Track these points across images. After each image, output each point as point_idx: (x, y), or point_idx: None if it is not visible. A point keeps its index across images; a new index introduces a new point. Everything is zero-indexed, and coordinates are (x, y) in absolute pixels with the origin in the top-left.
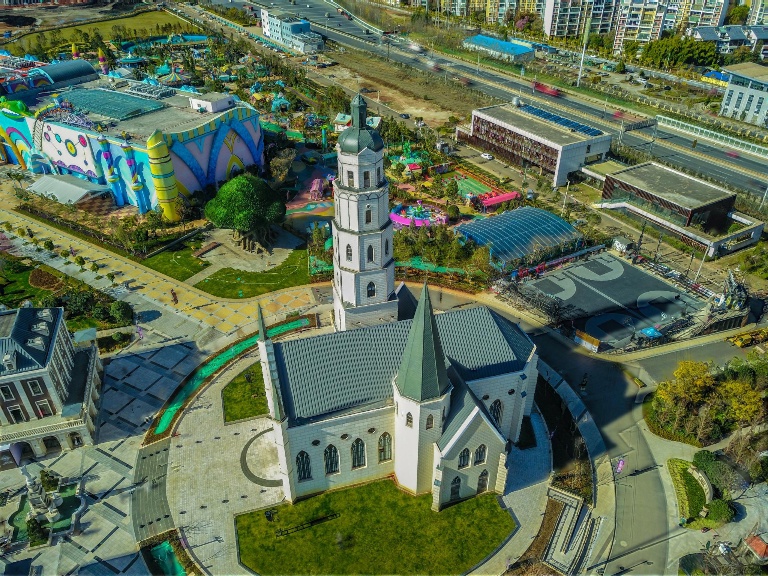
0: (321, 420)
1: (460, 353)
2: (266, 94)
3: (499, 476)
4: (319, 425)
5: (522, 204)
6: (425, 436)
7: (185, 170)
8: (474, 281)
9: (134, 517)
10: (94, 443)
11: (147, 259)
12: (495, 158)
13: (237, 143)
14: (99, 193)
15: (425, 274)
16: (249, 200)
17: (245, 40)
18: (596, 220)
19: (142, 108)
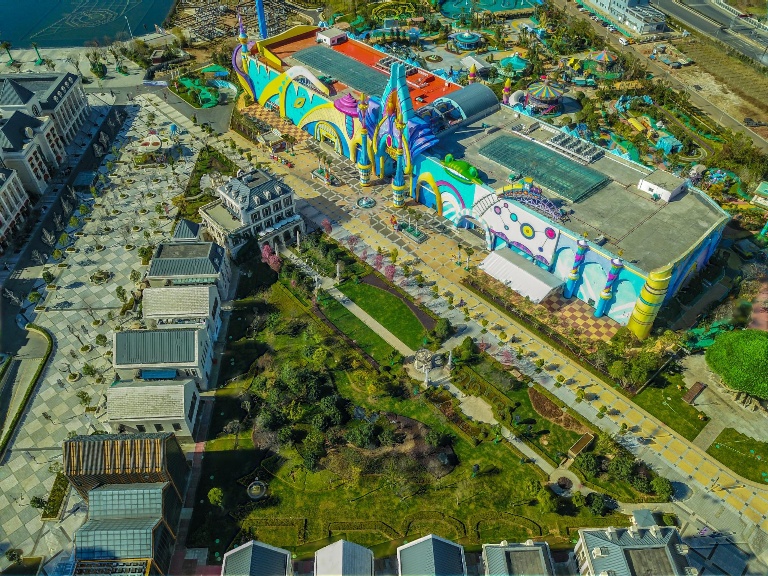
0: None
1: None
2: (640, 118)
3: None
4: None
5: None
6: None
7: None
8: None
9: None
10: None
11: (638, 396)
12: None
13: None
14: (557, 288)
15: None
16: None
17: (587, 21)
18: None
19: (591, 186)
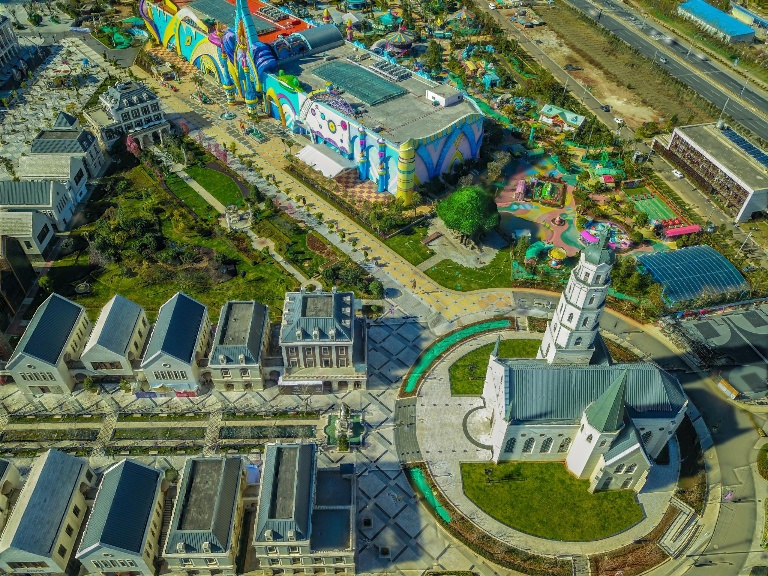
0: (531, 424)
1: (632, 398)
2: (477, 61)
3: (639, 482)
4: (529, 427)
5: (701, 238)
6: (597, 450)
7: (421, 165)
8: (645, 313)
9: (397, 446)
10: (367, 388)
11: (388, 239)
12: (686, 177)
13: (462, 141)
14: (350, 169)
15: None
16: (475, 211)
17: None
18: (766, 276)
19: (388, 95)
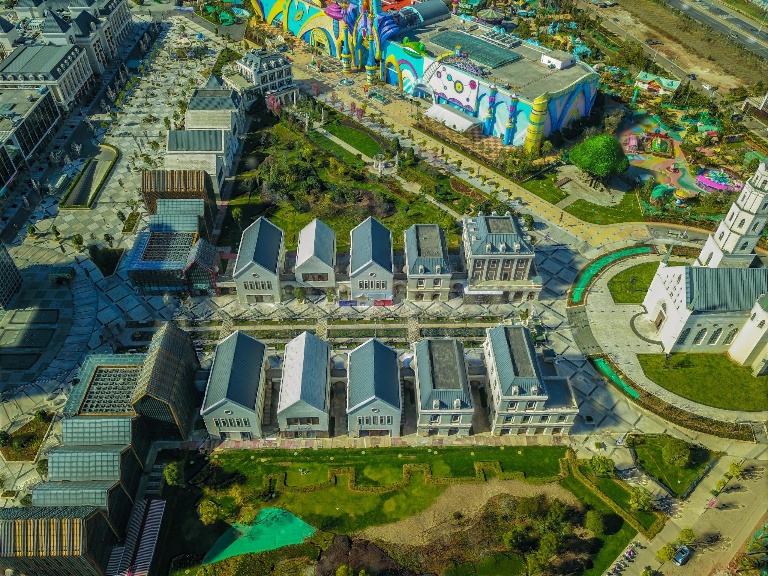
0: (709, 314)
1: None
2: (564, 36)
3: None
4: (707, 316)
5: None
6: (767, 334)
7: (548, 119)
8: None
9: (577, 343)
10: (538, 300)
11: (524, 183)
12: None
13: (580, 99)
14: (477, 125)
15: None
16: (610, 155)
17: None
18: None
19: (507, 59)
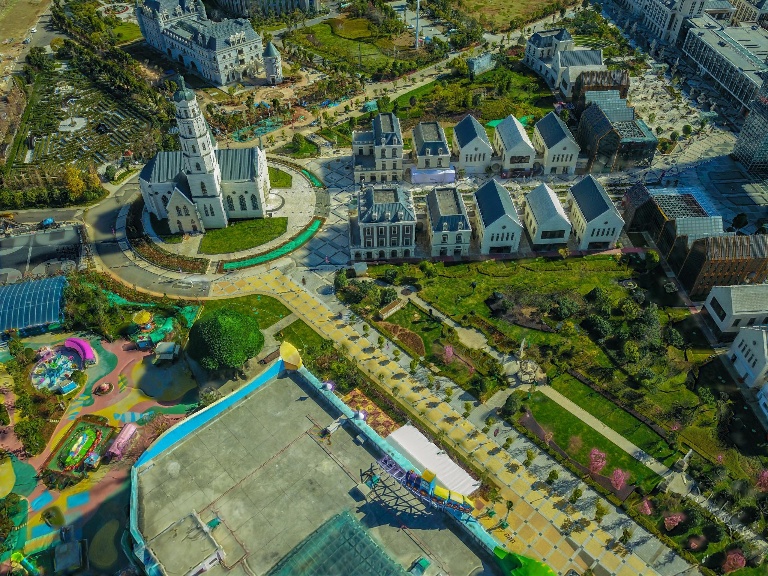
0: None
1: None
2: None
3: None
4: None
5: None
6: None
7: None
8: None
9: None
10: None
11: None
12: None
13: None
14: None
15: (121, 291)
16: None
17: None
18: None
19: None
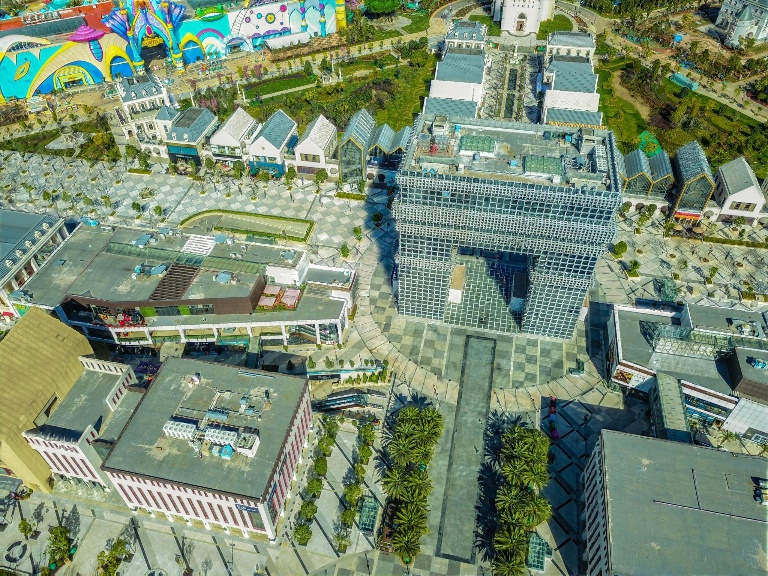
0: None
1: None
2: None
3: None
4: None
5: None
6: None
7: None
8: None
9: (525, 52)
10: None
11: (376, 39)
12: None
13: None
14: None
15: (446, 0)
16: None
17: None
18: None
19: None
